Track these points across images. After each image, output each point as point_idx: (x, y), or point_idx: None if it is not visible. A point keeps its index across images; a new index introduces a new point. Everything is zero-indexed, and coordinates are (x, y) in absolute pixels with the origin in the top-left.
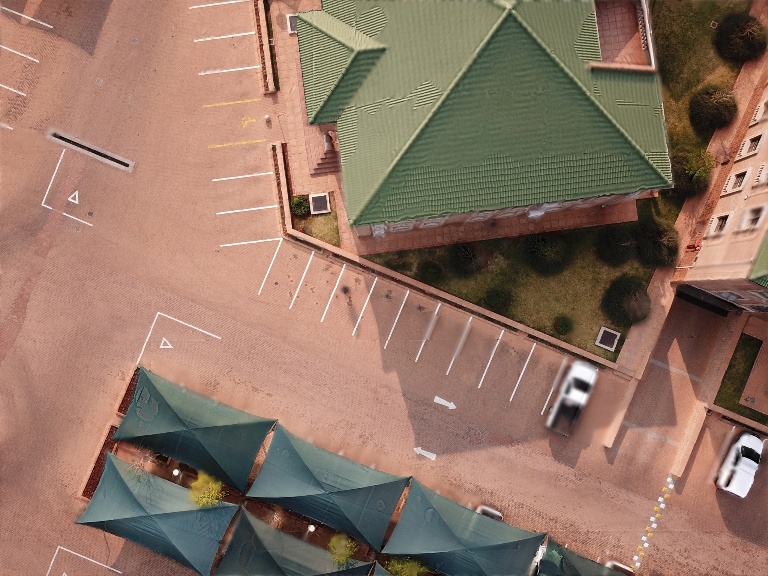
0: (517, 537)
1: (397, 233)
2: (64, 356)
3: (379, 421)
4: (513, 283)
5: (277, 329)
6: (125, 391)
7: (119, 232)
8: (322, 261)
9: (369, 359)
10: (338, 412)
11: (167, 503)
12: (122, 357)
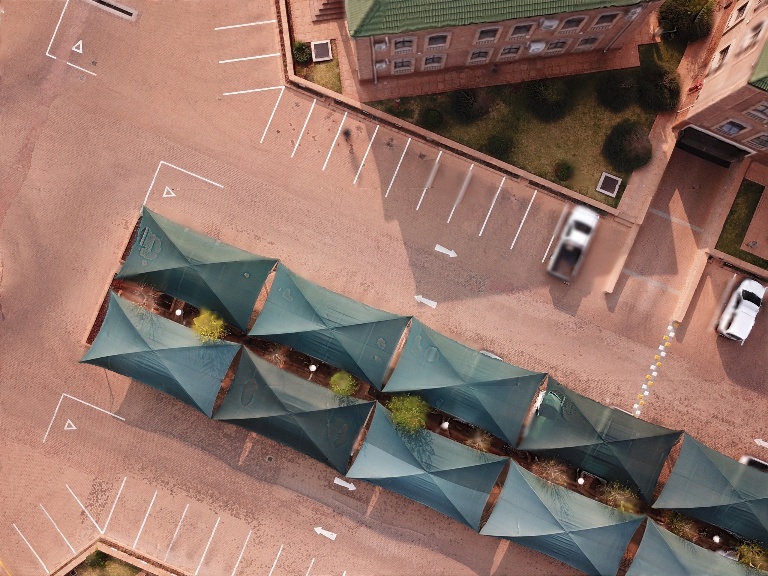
0: (517, 374)
1: (399, 79)
2: (68, 205)
3: (380, 269)
4: (514, 130)
5: (279, 177)
6: (128, 239)
7: (122, 81)
8: (324, 109)
9: (370, 207)
10: (339, 260)
11: (170, 340)
12: (125, 206)
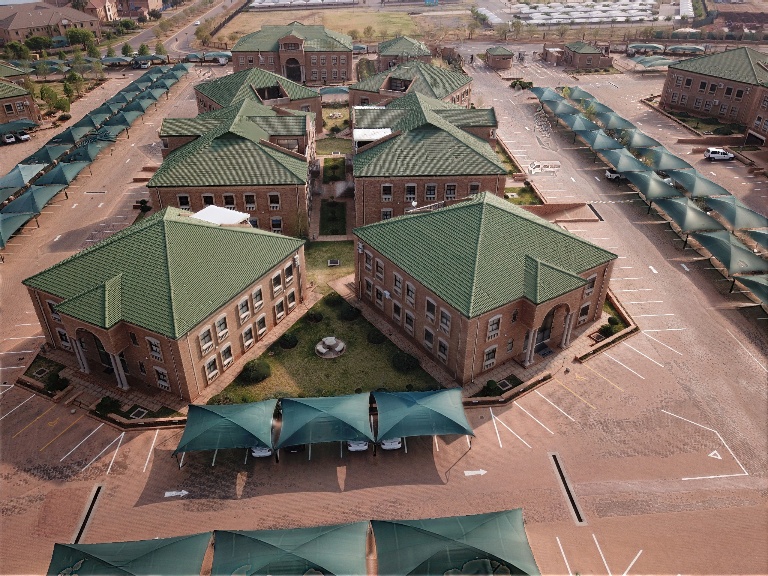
0: None
1: None
2: None
3: None
4: None
5: None
6: None
7: None
8: None
9: None
10: None
11: None
12: None
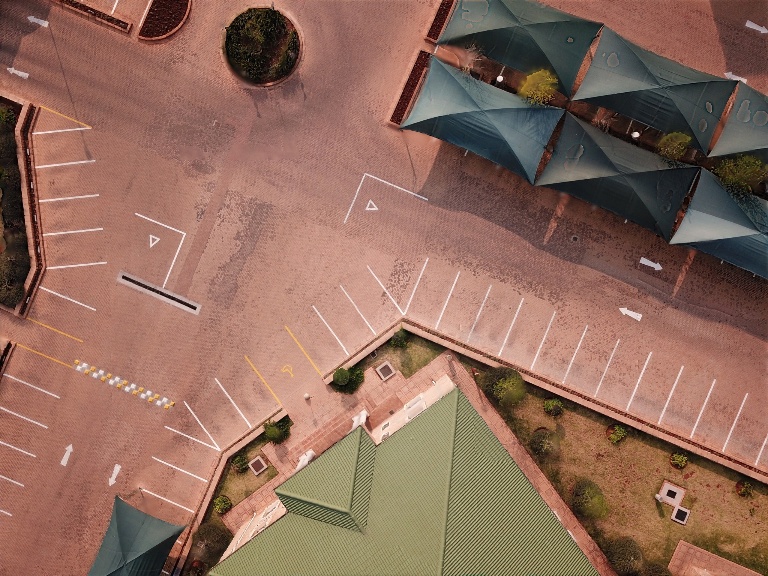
0: None
1: None
2: None
3: (690, 46)
4: None
5: None
6: (435, 16)
7: None
8: None
9: None
10: (648, 37)
11: (497, 102)
12: None
